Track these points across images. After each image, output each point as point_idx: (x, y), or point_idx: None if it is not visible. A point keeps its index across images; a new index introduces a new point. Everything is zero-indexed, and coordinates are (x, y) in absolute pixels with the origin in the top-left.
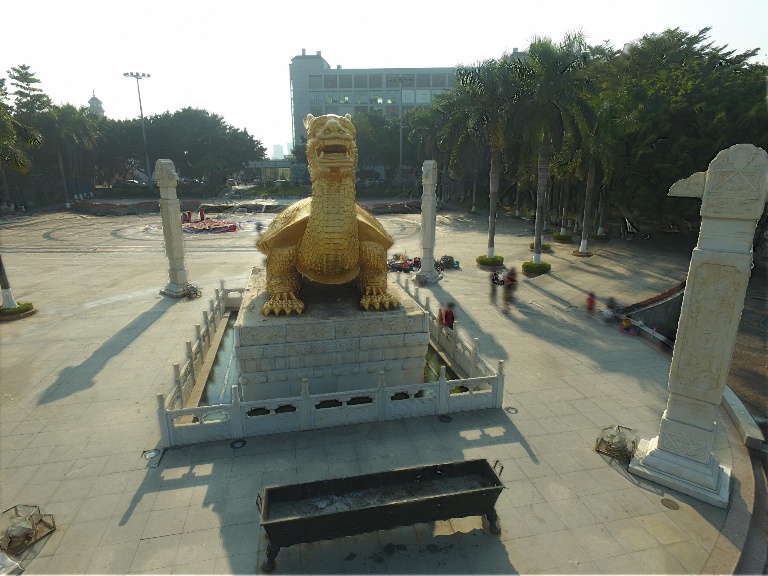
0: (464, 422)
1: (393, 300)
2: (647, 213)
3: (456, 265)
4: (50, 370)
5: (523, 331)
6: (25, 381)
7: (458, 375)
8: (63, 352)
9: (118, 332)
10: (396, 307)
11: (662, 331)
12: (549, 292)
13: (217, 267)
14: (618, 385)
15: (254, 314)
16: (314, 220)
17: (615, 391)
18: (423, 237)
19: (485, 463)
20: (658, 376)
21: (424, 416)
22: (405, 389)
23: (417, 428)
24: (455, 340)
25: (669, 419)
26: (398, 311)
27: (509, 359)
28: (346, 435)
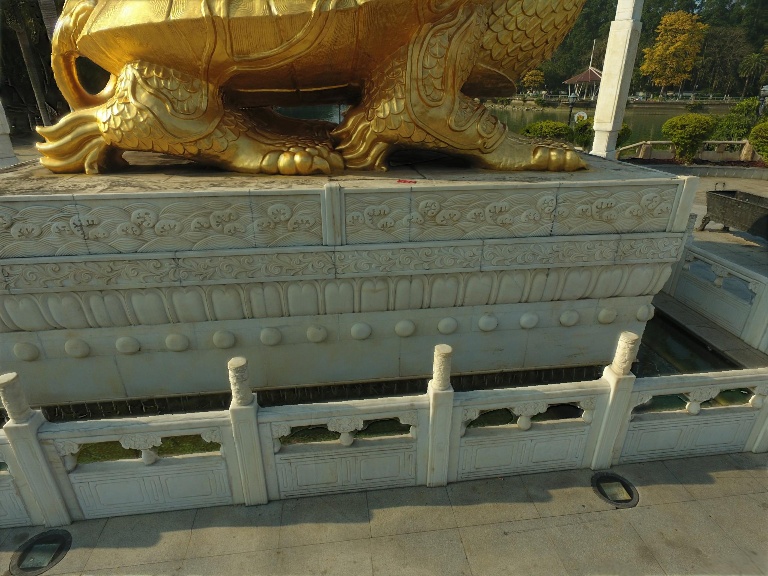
0: None
1: None
2: (89, 86)
3: None
4: None
5: None
6: None
7: None
8: None
9: None
10: None
11: None
12: None
13: None
14: None
15: None
16: None
17: None
18: None
19: (713, 192)
20: None
21: None
22: None
23: None
24: None
25: (608, 152)
26: None
27: None
28: None
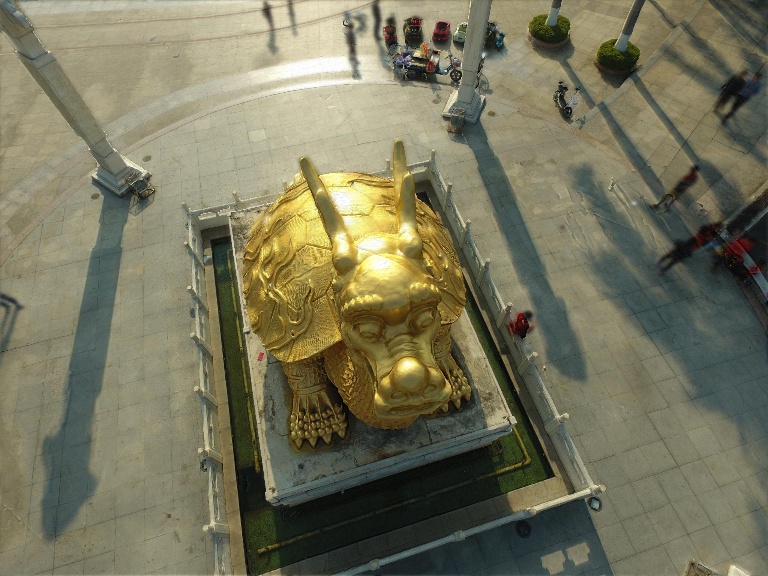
0: (544, 536)
1: (466, 393)
2: None
3: (500, 43)
4: (33, 439)
5: (603, 284)
6: (14, 472)
7: (530, 419)
8: (30, 387)
9: (79, 321)
10: (469, 399)
11: (766, 222)
12: (636, 148)
13: (145, 59)
14: (714, 431)
15: (281, 442)
16: (363, 409)
17: (710, 446)
18: (466, 54)
19: None
20: (761, 403)
21: (500, 526)
22: (485, 529)
23: (495, 553)
24: (529, 370)
25: None
26: (473, 412)
27: (588, 369)
28: (420, 575)
